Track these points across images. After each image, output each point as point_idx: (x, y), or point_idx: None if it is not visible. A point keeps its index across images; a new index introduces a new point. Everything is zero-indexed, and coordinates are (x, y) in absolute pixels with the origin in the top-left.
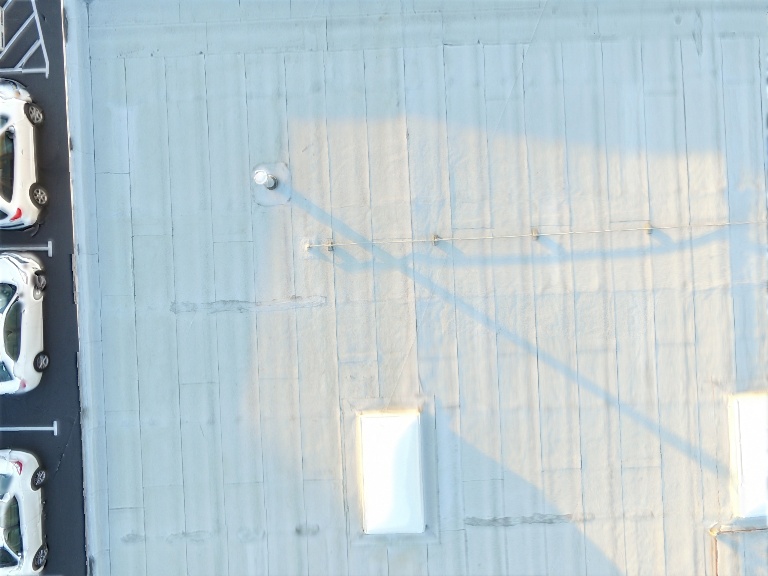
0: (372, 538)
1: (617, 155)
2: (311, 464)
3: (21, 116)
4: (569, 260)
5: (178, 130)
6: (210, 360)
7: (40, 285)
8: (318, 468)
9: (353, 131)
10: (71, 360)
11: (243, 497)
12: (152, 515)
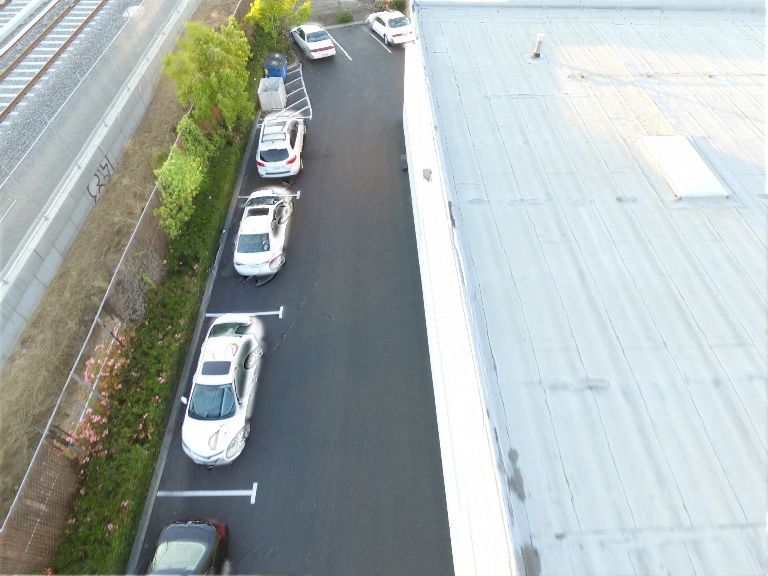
0: (685, 203)
1: (735, 55)
2: (613, 164)
3: (301, 122)
4: (737, 84)
5: (474, 42)
6: (517, 117)
7: (286, 215)
8: (619, 166)
9: (576, 44)
10: (305, 260)
11: (565, 180)
12: (492, 189)
